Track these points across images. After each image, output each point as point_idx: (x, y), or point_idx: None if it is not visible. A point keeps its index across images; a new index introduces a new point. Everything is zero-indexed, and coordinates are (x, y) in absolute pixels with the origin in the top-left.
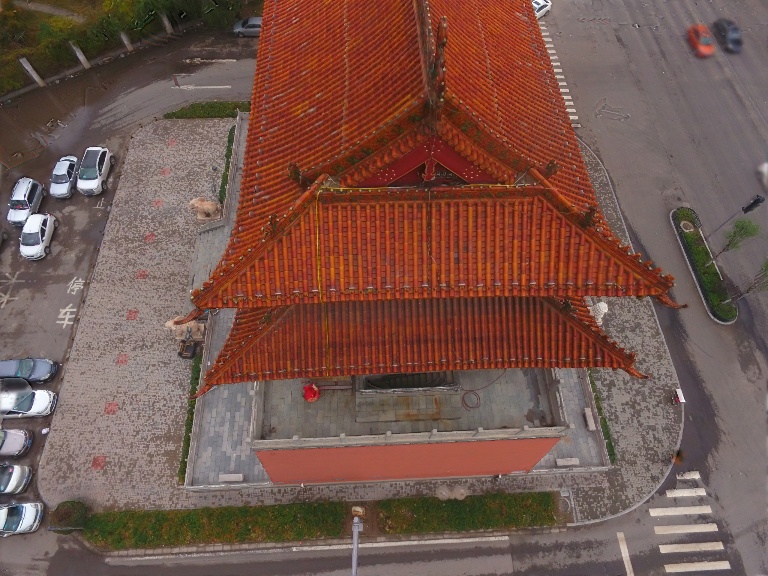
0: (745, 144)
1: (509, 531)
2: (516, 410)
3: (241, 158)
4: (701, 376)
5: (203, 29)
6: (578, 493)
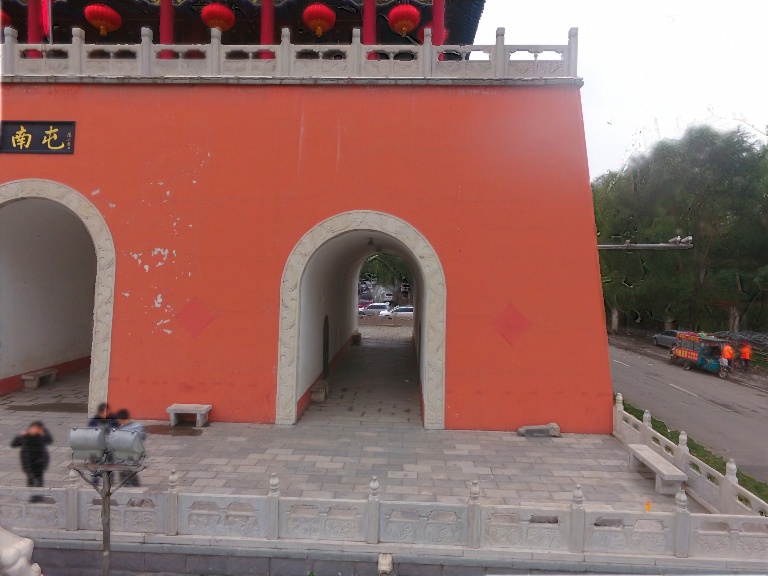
0: None
1: None
2: None
3: (411, 327)
4: None
5: (644, 338)
6: None
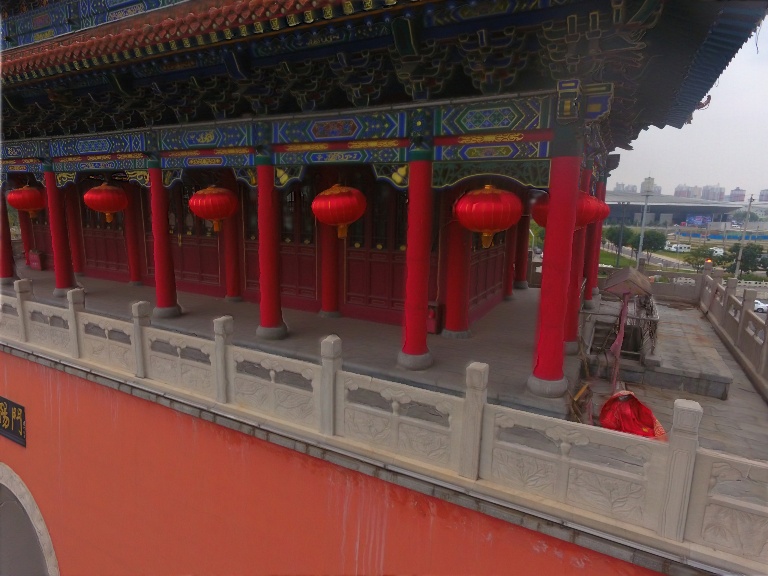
0: None
1: None
2: (672, 311)
3: None
4: None
5: None
6: None
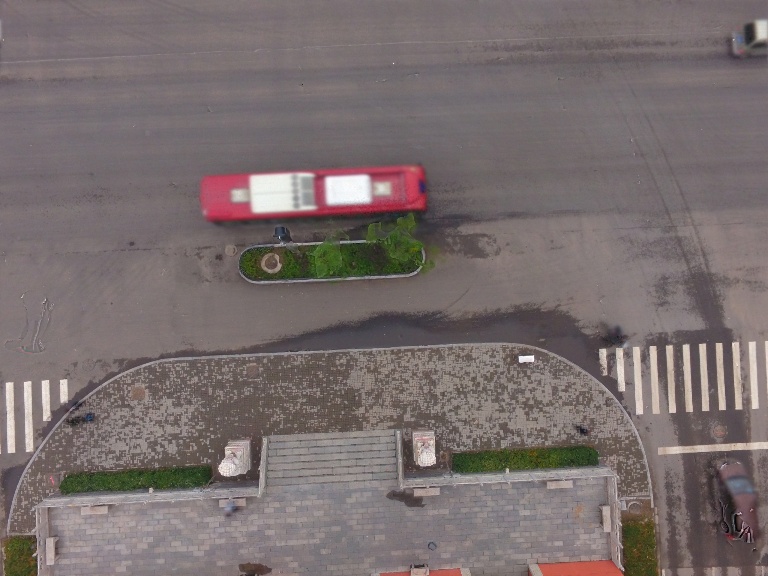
0: (103, 113)
1: (658, 569)
2: None
3: None
4: (492, 311)
5: None
6: (623, 491)
